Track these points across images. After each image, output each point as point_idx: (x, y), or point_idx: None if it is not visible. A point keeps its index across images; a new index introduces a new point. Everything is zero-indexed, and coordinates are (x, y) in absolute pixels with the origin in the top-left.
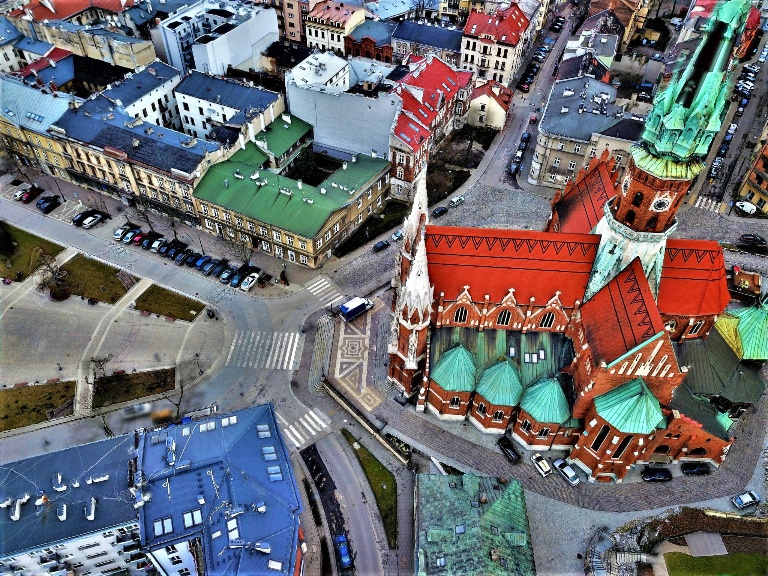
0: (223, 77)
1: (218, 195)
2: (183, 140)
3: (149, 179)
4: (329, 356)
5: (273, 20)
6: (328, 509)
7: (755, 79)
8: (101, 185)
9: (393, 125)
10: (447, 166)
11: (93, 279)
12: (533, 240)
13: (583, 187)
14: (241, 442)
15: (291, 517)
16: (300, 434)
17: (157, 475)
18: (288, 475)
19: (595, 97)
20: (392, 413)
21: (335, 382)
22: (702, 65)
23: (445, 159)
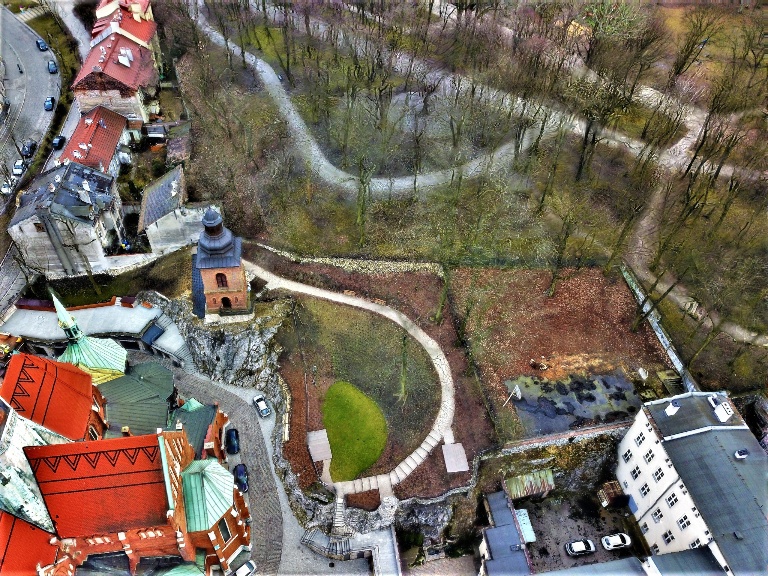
0: None
1: None
2: None
3: None
4: None
5: None
6: None
7: None
8: None
9: None
10: None
11: None
12: None
13: None
14: None
15: None
16: None
17: None
18: None
19: None
20: None
21: None
22: None
23: None
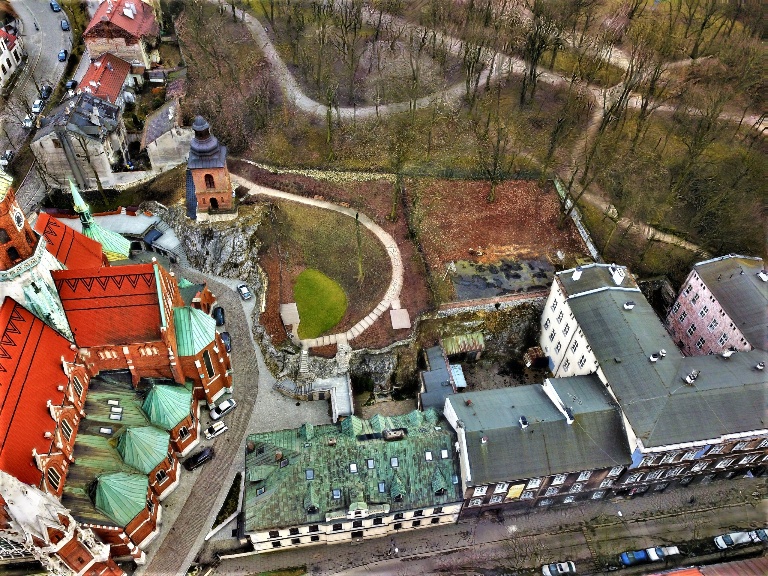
0: None
1: None
2: None
3: None
4: None
5: None
6: None
7: None
8: None
9: None
10: None
11: None
12: None
13: None
14: None
15: None
16: None
17: None
18: None
19: None
20: None
21: None
22: None
23: None
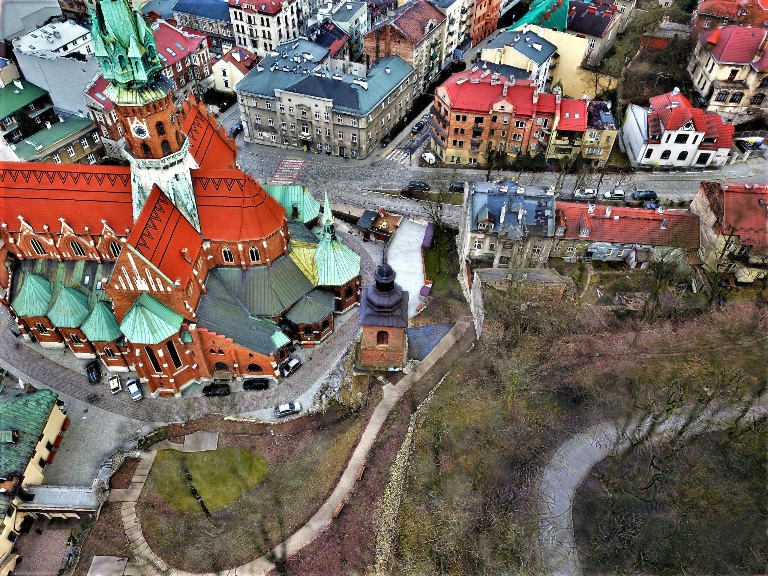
0: None
1: None
2: None
3: None
4: None
5: None
6: None
7: None
8: None
9: (88, 85)
10: None
11: None
12: (76, 172)
13: None
14: None
15: None
16: None
17: None
18: None
19: (294, 57)
20: (4, 343)
21: None
22: None
23: None
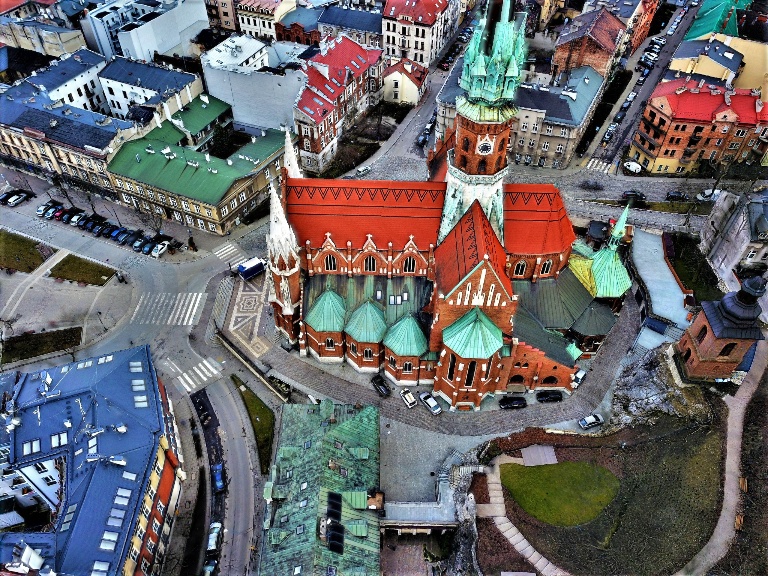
0: (144, 61)
1: (130, 169)
2: (97, 119)
3: (68, 157)
4: (226, 311)
5: (201, 8)
6: (210, 443)
7: (661, 51)
8: (27, 166)
9: (297, 99)
10: (360, 140)
11: (13, 251)
12: (386, 189)
13: (449, 144)
14: (111, 375)
15: (151, 437)
16: (192, 380)
17: (29, 403)
18: (154, 403)
19: None
20: (278, 358)
21: (228, 333)
22: (491, 15)
23: (358, 133)
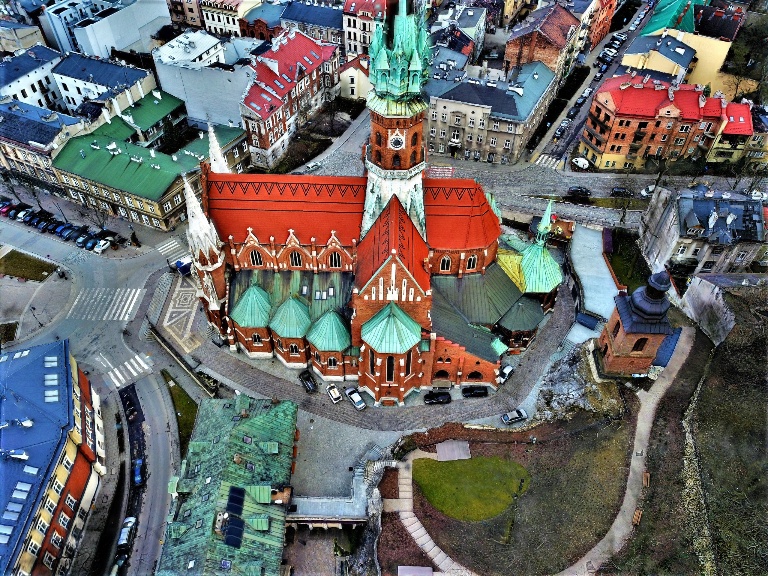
0: (98, 57)
1: (75, 165)
2: (43, 115)
3: (15, 153)
4: (161, 307)
5: (162, 4)
6: (133, 438)
7: (621, 47)
8: None
9: (243, 95)
10: (313, 136)
11: None
12: (307, 184)
13: None
14: (24, 370)
15: (59, 432)
16: (122, 375)
17: None
18: (65, 398)
19: (440, 64)
20: (208, 354)
21: (162, 329)
22: (390, 9)
23: None
